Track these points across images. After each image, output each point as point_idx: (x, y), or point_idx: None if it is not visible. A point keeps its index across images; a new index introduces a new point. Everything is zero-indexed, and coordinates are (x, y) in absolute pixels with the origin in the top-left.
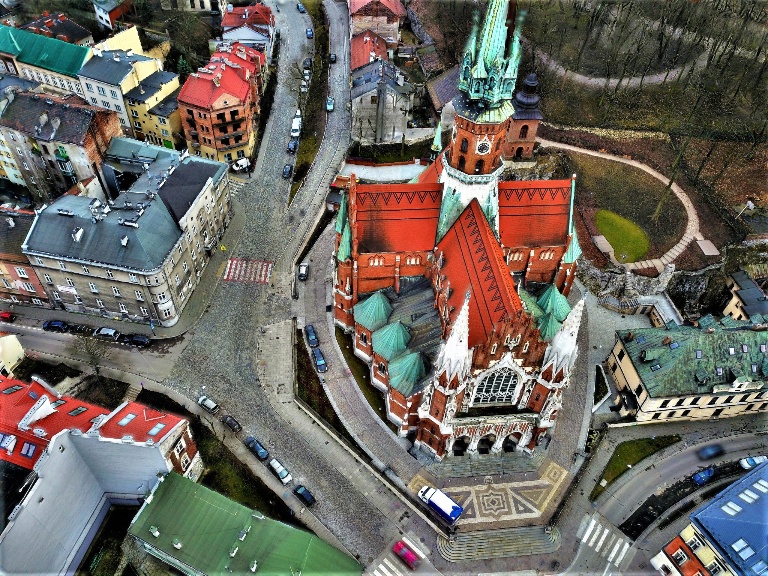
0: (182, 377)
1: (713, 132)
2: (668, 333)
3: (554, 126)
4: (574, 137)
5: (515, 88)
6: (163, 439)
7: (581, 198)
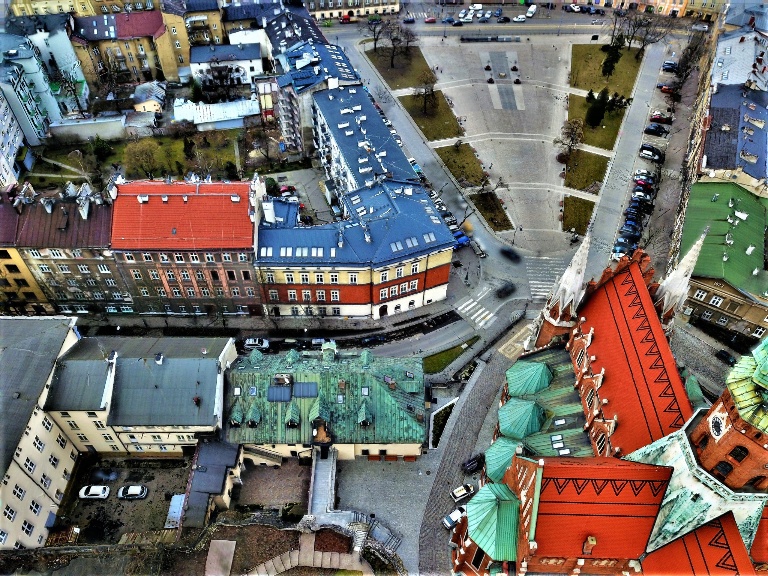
0: None
1: None
2: (382, 401)
3: None
4: None
5: None
6: None
7: None
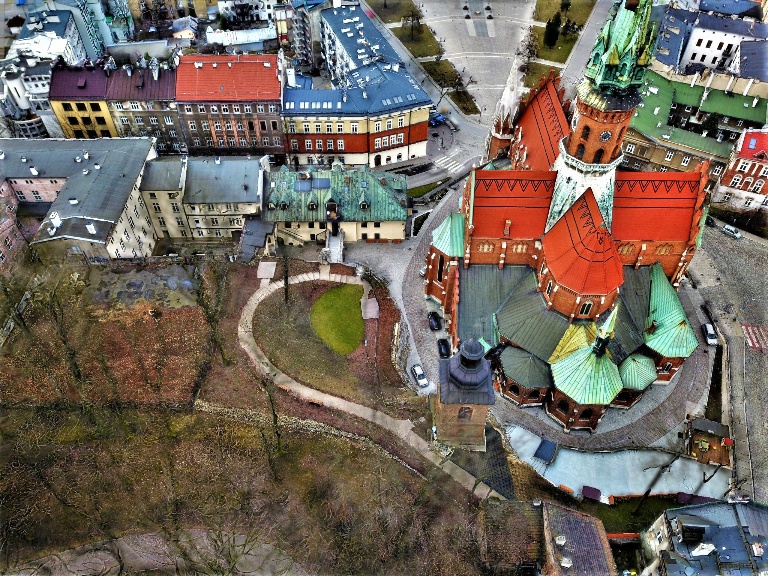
0: (766, 253)
1: (112, 404)
2: (376, 191)
3: (382, 449)
4: (356, 423)
5: (430, 574)
6: (744, 133)
7: (366, 371)
